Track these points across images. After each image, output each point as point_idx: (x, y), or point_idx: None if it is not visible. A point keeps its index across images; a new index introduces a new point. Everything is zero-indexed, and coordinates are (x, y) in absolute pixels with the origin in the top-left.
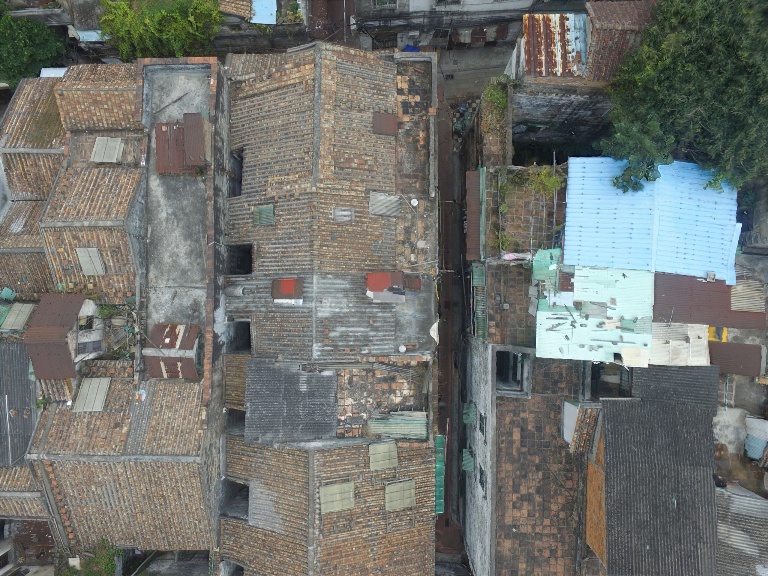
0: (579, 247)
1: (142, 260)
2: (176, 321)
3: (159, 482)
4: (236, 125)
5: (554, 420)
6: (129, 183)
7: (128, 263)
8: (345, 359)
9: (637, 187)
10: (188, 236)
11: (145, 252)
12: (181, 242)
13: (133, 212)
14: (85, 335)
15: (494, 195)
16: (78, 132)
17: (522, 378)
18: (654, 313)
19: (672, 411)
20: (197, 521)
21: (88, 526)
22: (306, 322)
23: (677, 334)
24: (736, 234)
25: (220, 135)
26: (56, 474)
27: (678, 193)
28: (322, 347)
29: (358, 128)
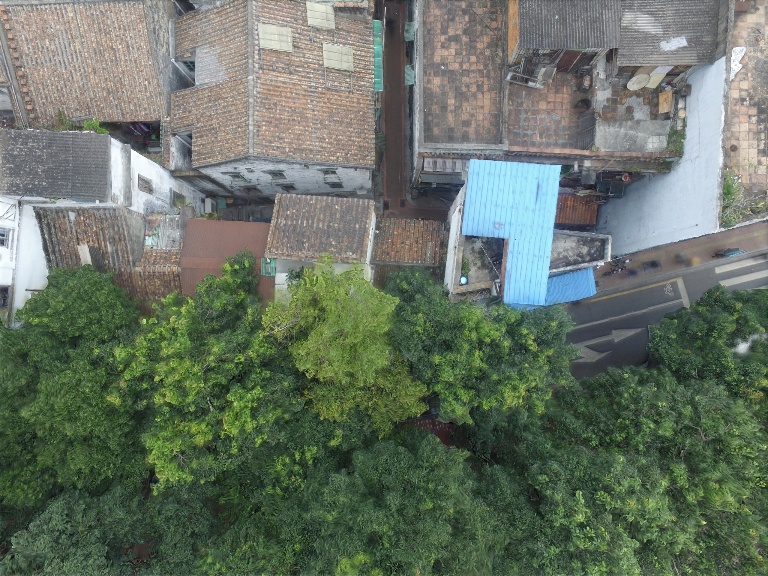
0: None
1: None
2: None
3: (108, 30)
4: None
5: None
6: None
7: None
8: None
9: None
10: None
11: None
12: None
13: None
14: None
15: None
16: None
17: None
18: None
19: None
20: (147, 81)
21: (45, 95)
22: None
23: None
24: None
25: None
26: (11, 26)
27: None
28: None
29: None
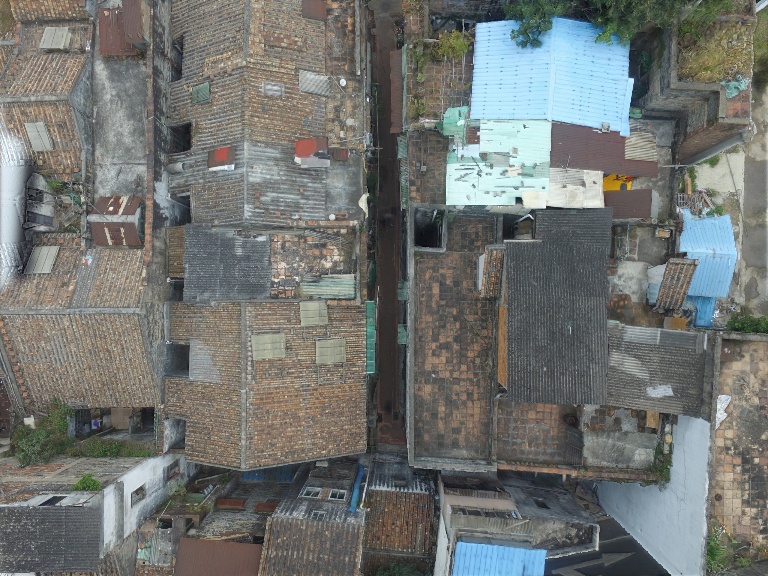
0: (484, 103)
1: (88, 137)
2: (121, 195)
3: (103, 336)
4: (177, 15)
5: (470, 275)
6: (75, 66)
7: (74, 139)
8: (276, 222)
9: (534, 43)
10: (131, 116)
11: (91, 131)
12: (125, 122)
13: (77, 89)
14: (35, 206)
15: (414, 70)
16: (28, 24)
17: (441, 238)
18: (552, 160)
19: (570, 250)
20: (141, 376)
21: (40, 385)
22: (239, 187)
23: (573, 179)
24: (629, 89)
25: (160, 21)
26: (8, 330)
27: (573, 50)
28: (253, 209)
29: (288, 11)
